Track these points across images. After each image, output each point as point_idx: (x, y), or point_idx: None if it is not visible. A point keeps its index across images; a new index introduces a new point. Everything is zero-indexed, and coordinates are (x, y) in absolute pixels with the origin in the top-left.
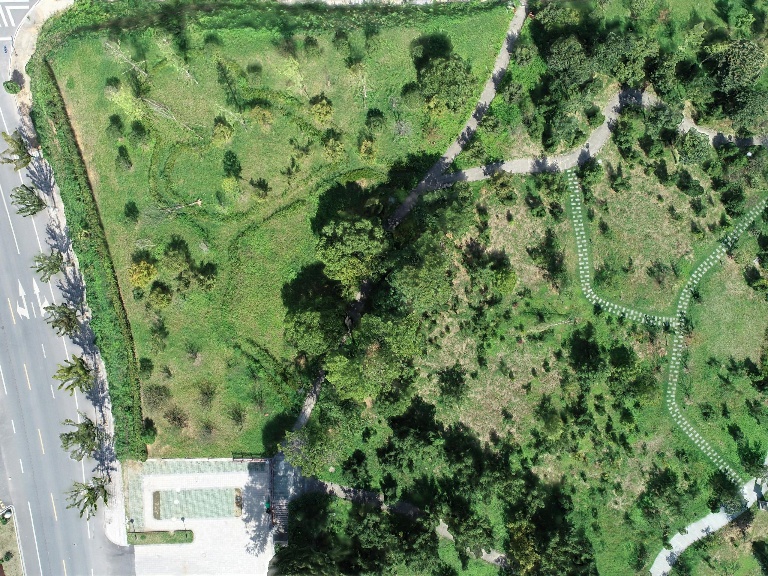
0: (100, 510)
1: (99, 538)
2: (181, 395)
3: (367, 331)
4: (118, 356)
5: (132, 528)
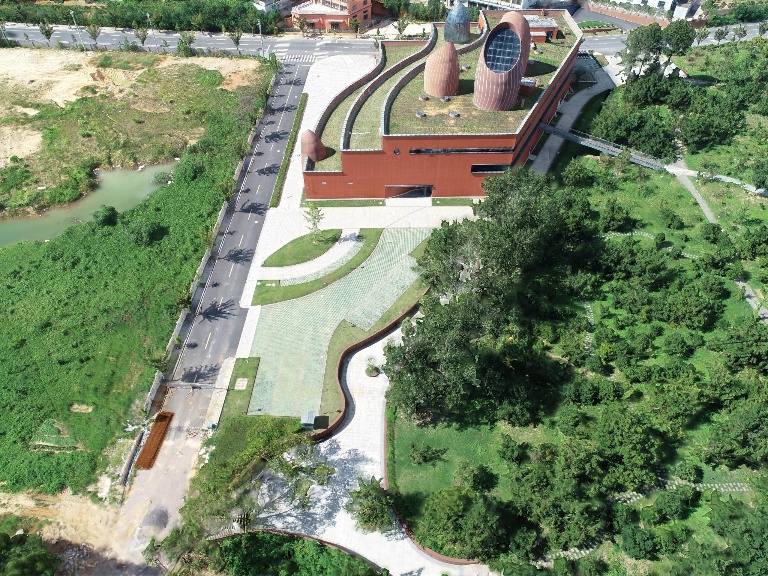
0: None
1: None
2: None
3: None
4: None
5: None
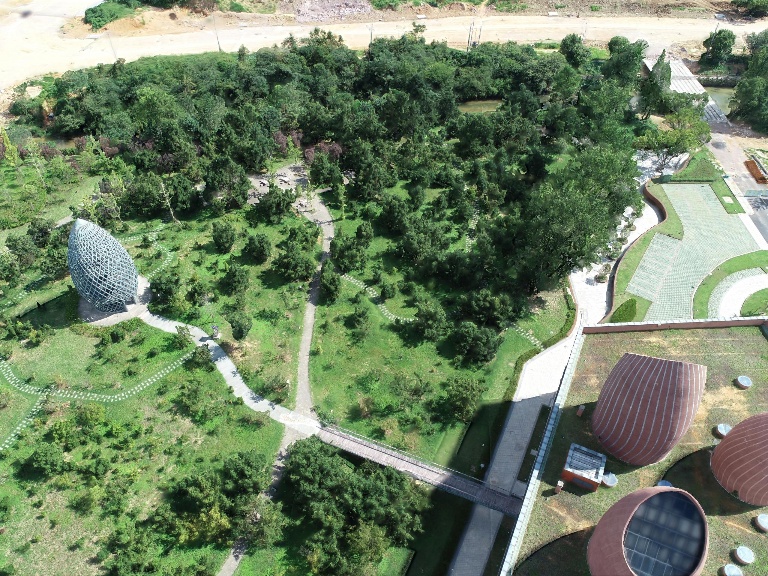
0: None
1: None
2: None
3: None
4: None
5: None
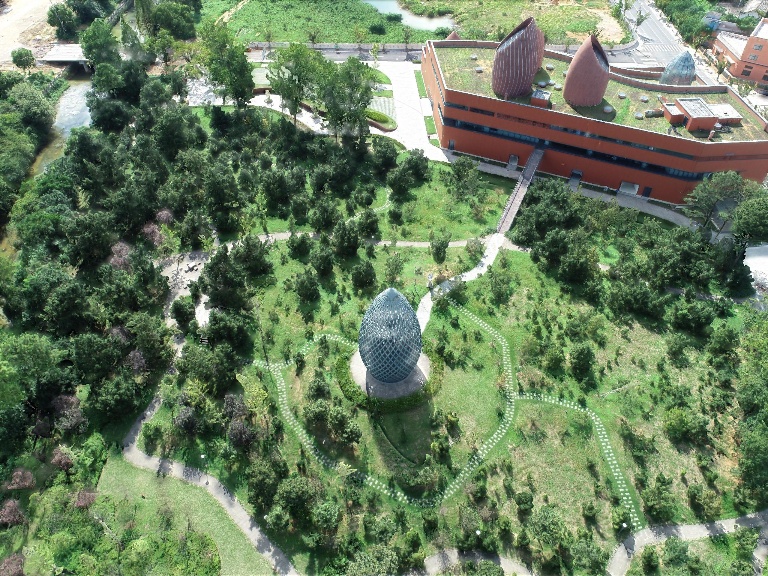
0: None
1: None
2: None
3: None
4: None
5: None
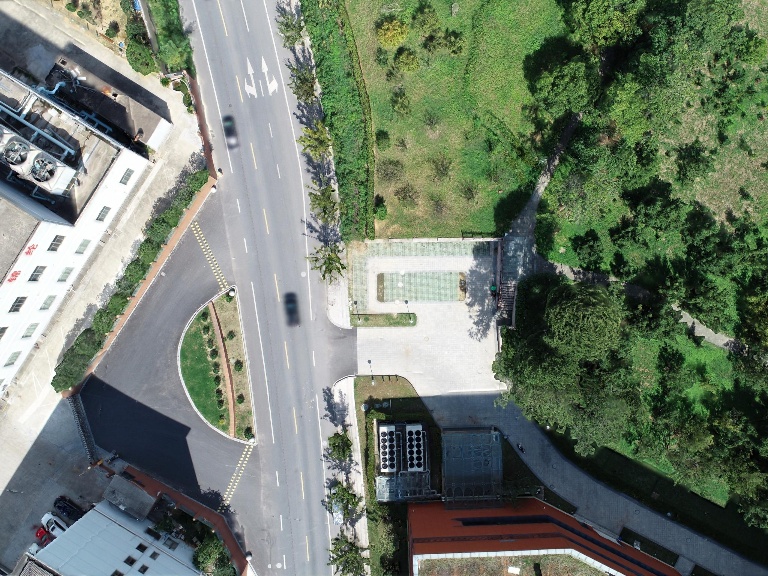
0: (323, 292)
1: (321, 320)
2: (414, 171)
3: (645, 70)
4: (355, 127)
5: (355, 310)
